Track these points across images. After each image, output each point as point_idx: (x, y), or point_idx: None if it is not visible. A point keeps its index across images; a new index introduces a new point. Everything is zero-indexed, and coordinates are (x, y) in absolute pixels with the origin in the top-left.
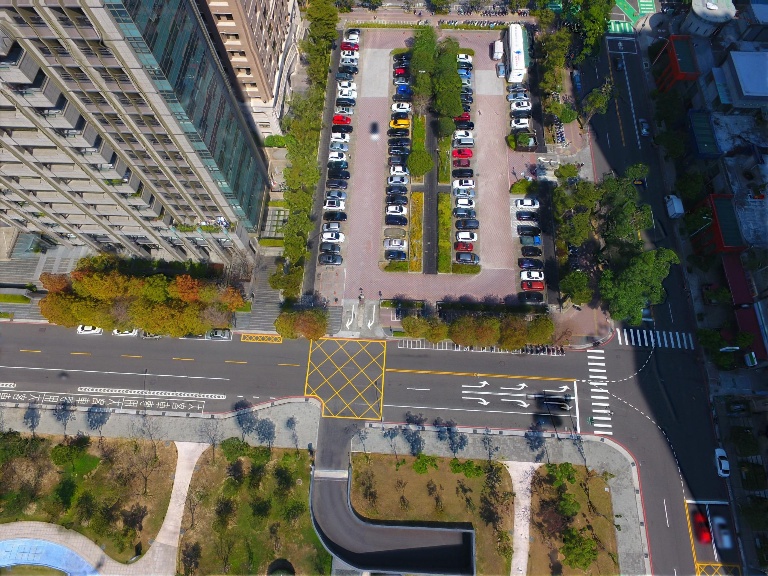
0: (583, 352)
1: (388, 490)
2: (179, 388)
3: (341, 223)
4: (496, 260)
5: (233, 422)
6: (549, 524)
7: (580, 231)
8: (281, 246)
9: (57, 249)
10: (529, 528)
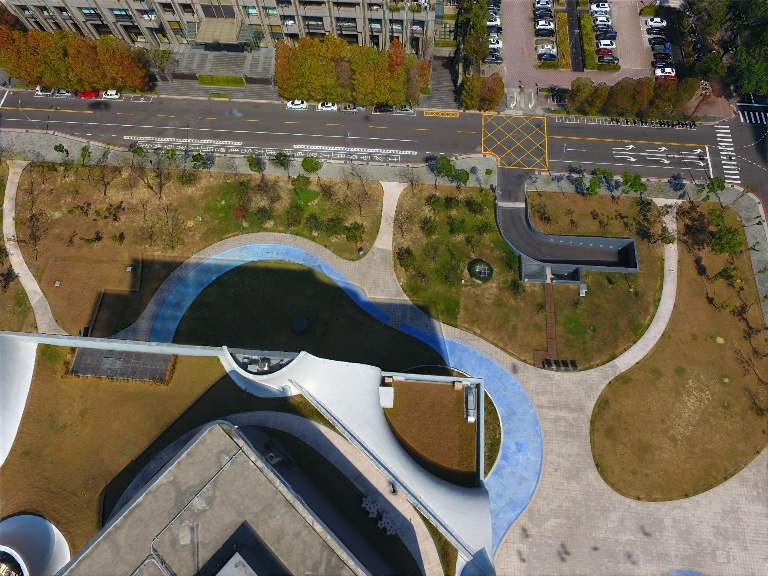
0: (711, 127)
1: (559, 216)
2: (377, 146)
3: (498, 35)
4: (632, 62)
5: (426, 169)
6: (693, 240)
7: (716, 20)
8: (452, 46)
9: (260, 50)
10: (677, 243)
